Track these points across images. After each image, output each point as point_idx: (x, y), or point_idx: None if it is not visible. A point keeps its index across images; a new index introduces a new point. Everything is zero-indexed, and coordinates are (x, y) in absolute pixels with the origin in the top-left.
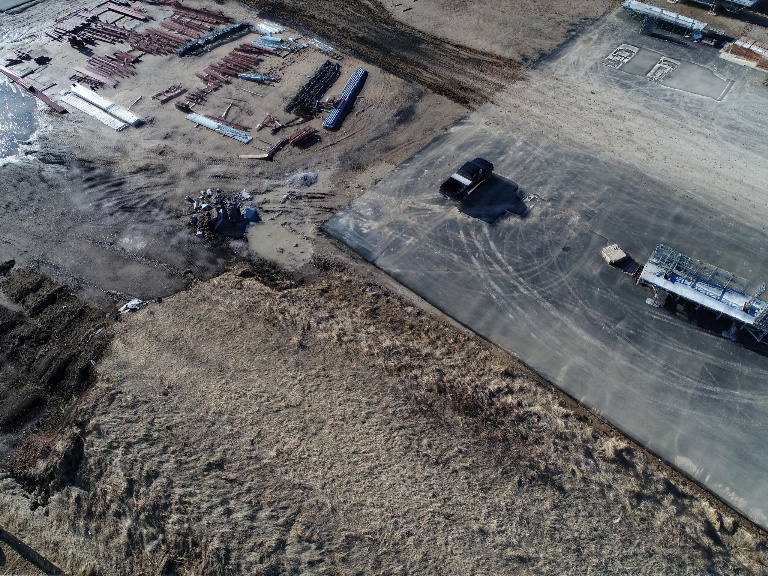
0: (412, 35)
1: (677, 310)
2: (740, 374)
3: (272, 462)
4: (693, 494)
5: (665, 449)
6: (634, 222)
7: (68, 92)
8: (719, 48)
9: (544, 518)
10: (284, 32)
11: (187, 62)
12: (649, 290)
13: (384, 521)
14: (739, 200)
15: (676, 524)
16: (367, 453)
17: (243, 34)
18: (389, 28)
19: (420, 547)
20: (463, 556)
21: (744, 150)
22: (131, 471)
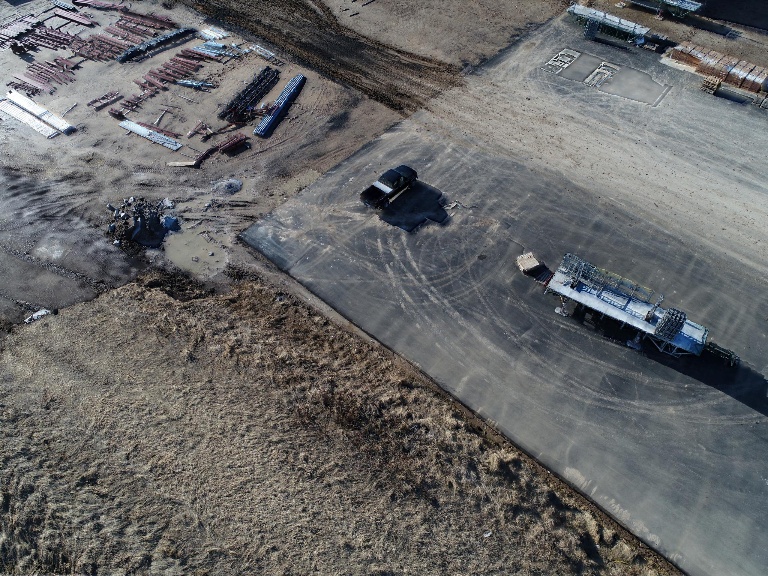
0: (356, 40)
1: (585, 319)
2: (640, 384)
3: (145, 477)
4: (578, 506)
5: (555, 461)
6: (553, 230)
7: (4, 99)
8: (661, 53)
9: (413, 533)
10: (228, 37)
11: (127, 68)
12: (559, 299)
13: (250, 536)
14: (661, 207)
15: (550, 538)
16: (242, 467)
17: (187, 40)
18: (334, 33)
19: (284, 563)
20: (326, 572)
21: (672, 156)
22: (8, 485)
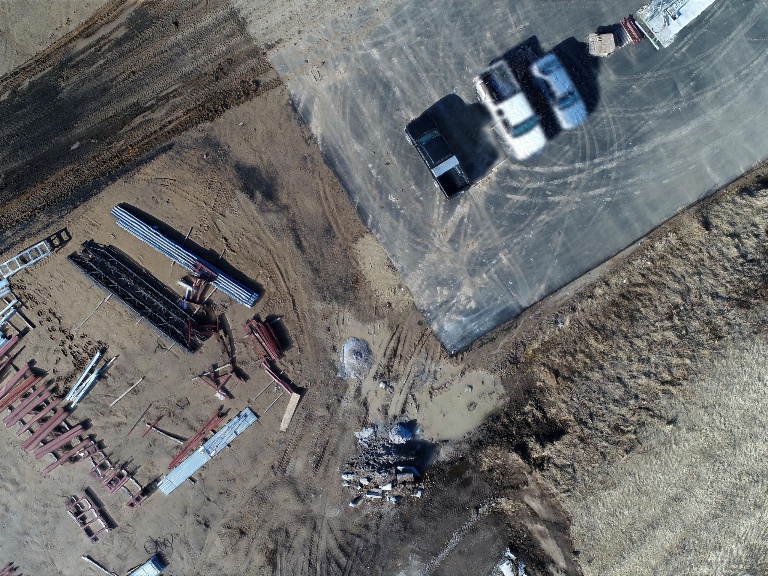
0: (21, 92)
1: None
2: (765, 12)
3: None
4: None
5: None
6: None
7: None
8: None
9: None
10: None
11: None
12: None
13: None
14: None
15: None
16: None
17: None
18: None
19: None
20: None
21: None
22: None
